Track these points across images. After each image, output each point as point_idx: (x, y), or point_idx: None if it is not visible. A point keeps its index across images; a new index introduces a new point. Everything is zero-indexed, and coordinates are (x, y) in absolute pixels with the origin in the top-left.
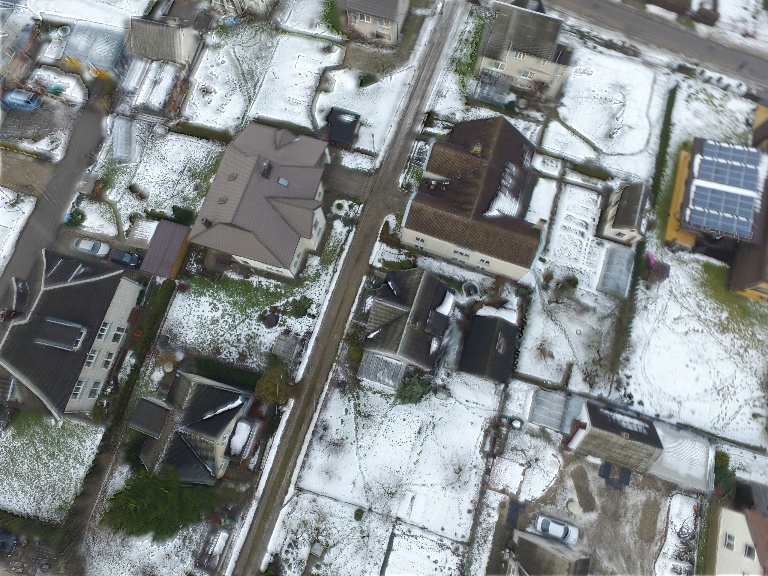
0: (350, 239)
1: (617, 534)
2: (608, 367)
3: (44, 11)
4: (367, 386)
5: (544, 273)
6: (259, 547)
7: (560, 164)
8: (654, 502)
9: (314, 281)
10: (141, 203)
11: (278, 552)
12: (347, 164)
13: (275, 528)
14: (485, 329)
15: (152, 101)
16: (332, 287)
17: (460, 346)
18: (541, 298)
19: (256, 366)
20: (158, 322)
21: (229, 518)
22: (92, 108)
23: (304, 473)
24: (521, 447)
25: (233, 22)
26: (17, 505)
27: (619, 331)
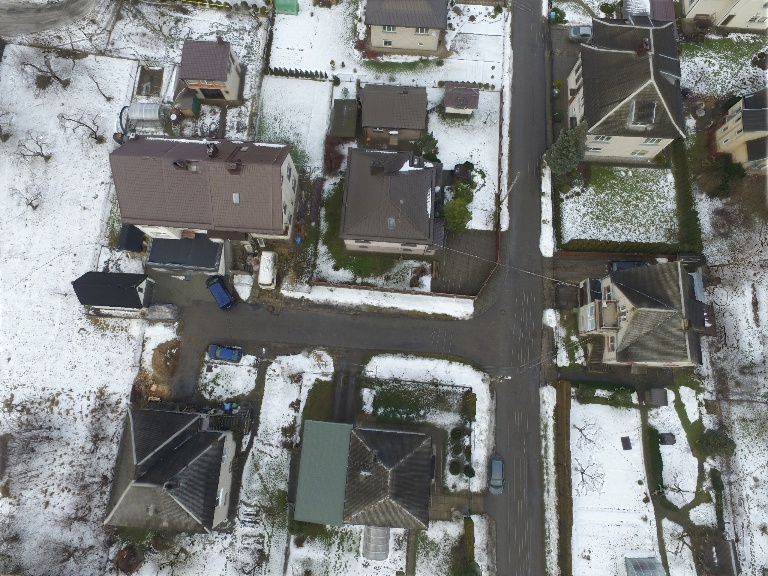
0: None
1: None
2: None
3: None
4: None
5: None
6: None
7: None
8: None
9: None
10: None
11: None
12: None
13: None
14: None
15: None
16: None
17: None
18: None
19: None
20: None
21: None
22: None
23: None
24: None
25: None
26: (627, 239)
27: None
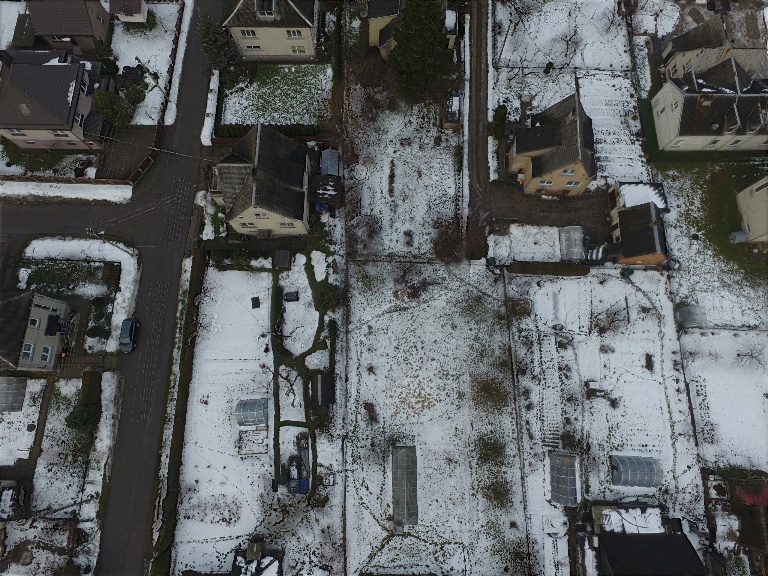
0: None
1: (734, 40)
2: None
3: None
4: None
5: None
6: (481, 108)
7: None
8: (752, 16)
9: None
10: None
11: None
12: None
13: (488, 94)
14: None
15: None
16: None
17: None
18: None
19: None
20: None
21: None
22: None
23: None
24: (647, 6)
25: None
26: None
27: None
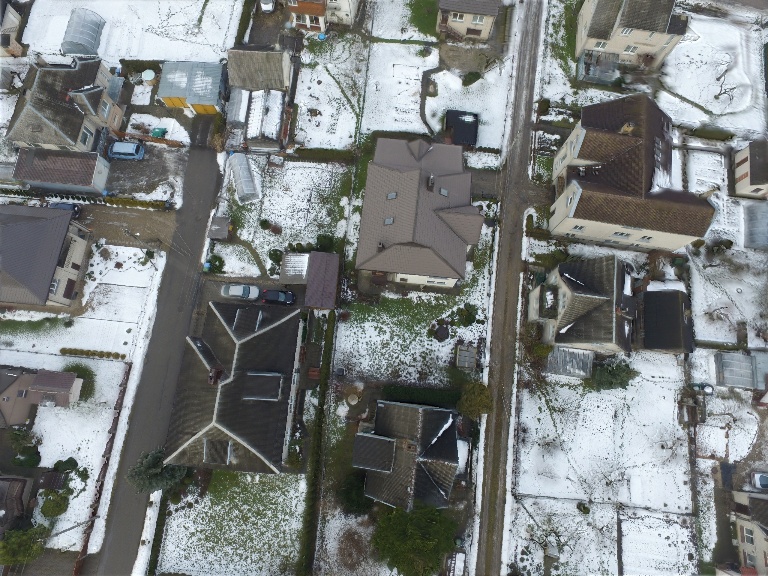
0: (497, 239)
1: None
2: None
3: (119, 58)
4: (553, 381)
5: None
6: (493, 560)
7: (677, 132)
8: None
9: (473, 287)
10: (276, 239)
11: (513, 561)
12: (473, 165)
13: (504, 538)
14: (666, 303)
15: (265, 133)
16: (493, 289)
17: (632, 325)
18: (695, 264)
19: (439, 382)
20: (330, 356)
21: (456, 538)
22: (197, 150)
23: (519, 478)
24: (717, 411)
25: (318, 40)
26: (235, 569)
27: None
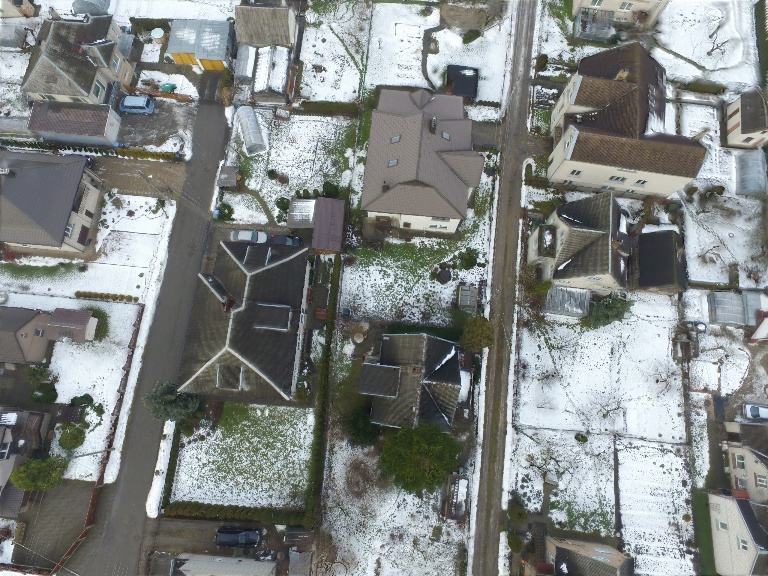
0: (497, 187)
1: None
2: (766, 261)
3: (128, 17)
4: (552, 320)
5: (685, 188)
6: (494, 487)
7: (671, 86)
8: None
9: (474, 232)
10: (283, 188)
11: (514, 488)
12: (474, 118)
13: (505, 467)
14: (660, 243)
15: (271, 87)
16: (493, 235)
17: (628, 267)
18: (688, 211)
19: (442, 321)
20: (336, 297)
21: (459, 466)
22: (206, 105)
23: (519, 410)
24: (710, 348)
25: (322, 1)
26: (246, 497)
27: (767, 227)
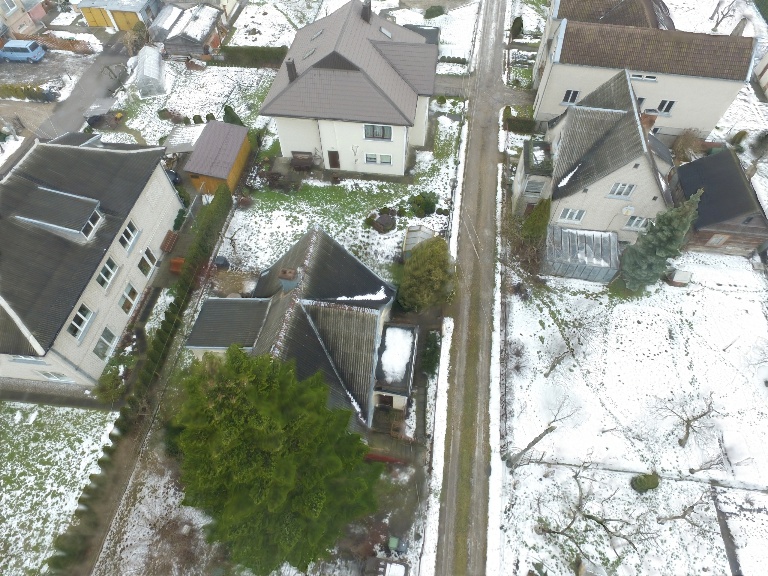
0: (465, 132)
1: None
2: None
3: None
4: (559, 286)
5: (726, 138)
6: None
7: None
8: None
9: (433, 176)
10: None
11: None
12: None
13: (489, 544)
14: (713, 168)
15: (187, 33)
16: (460, 179)
17: None
18: None
19: None
20: (210, 244)
21: None
22: (108, 56)
23: None
24: None
25: None
26: None
27: None
